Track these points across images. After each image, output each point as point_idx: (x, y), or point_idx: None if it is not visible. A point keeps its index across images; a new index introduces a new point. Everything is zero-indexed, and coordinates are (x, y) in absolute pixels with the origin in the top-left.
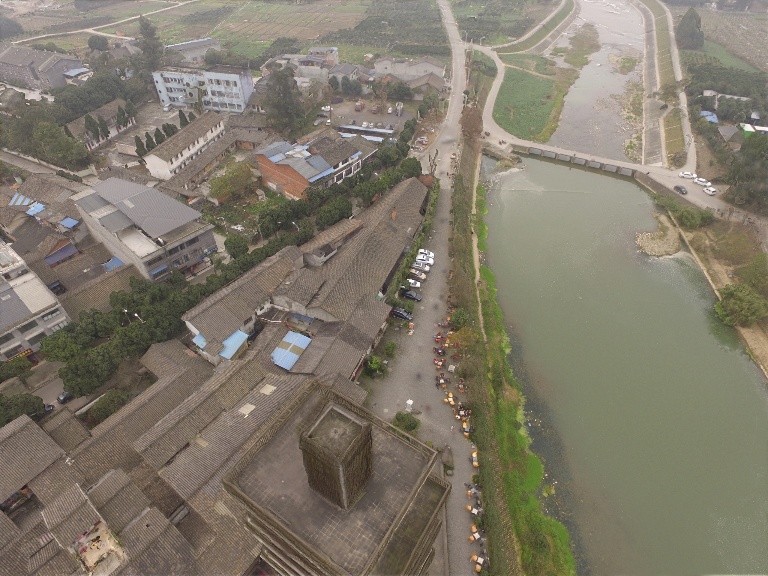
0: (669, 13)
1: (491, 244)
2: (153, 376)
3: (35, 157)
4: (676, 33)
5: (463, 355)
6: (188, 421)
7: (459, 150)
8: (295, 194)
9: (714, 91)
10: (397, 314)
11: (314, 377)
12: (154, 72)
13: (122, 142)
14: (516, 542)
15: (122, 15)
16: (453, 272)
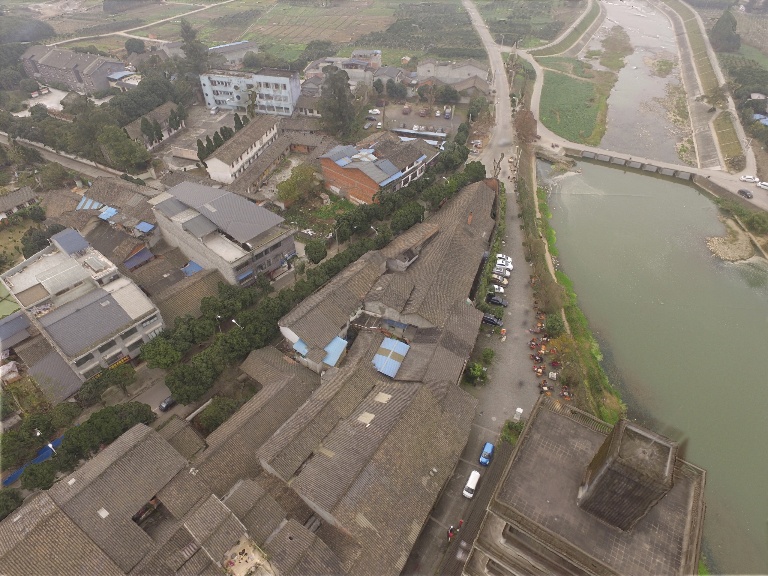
0: (698, 16)
1: (562, 249)
2: (252, 383)
3: (93, 160)
4: (711, 36)
5: (561, 362)
6: (309, 430)
7: (515, 153)
8: (361, 198)
9: (761, 94)
10: (487, 320)
11: (423, 385)
12: (201, 75)
13: (175, 145)
14: None
15: (151, 18)
16: (535, 277)
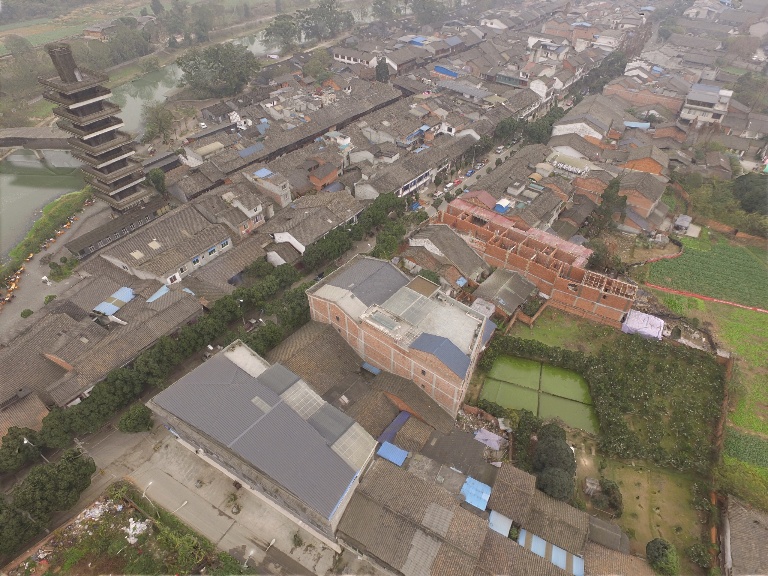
0: None
1: None
2: None
3: None
4: None
5: None
6: None
7: None
8: None
9: None
10: None
11: None
12: None
13: None
14: None
15: None
16: None
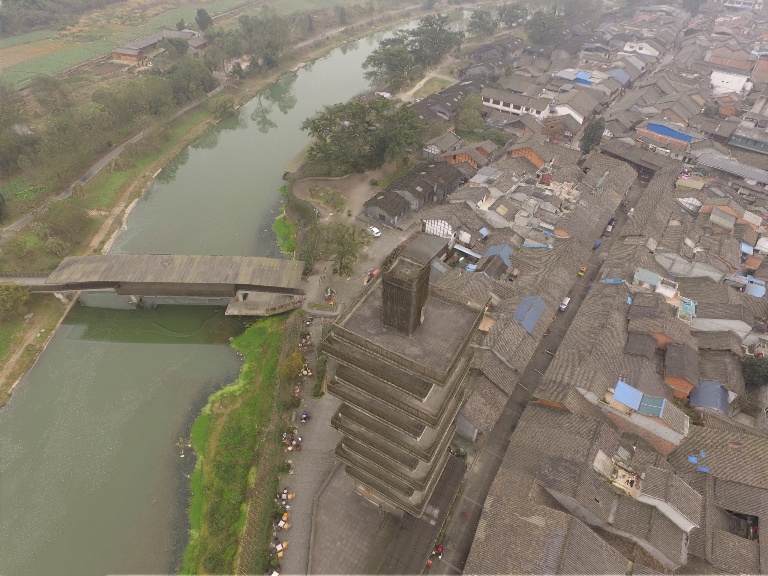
0: None
1: None
2: None
3: None
4: None
5: None
6: None
7: None
8: None
9: None
10: None
11: None
12: None
13: None
14: (236, 568)
15: None
16: None
